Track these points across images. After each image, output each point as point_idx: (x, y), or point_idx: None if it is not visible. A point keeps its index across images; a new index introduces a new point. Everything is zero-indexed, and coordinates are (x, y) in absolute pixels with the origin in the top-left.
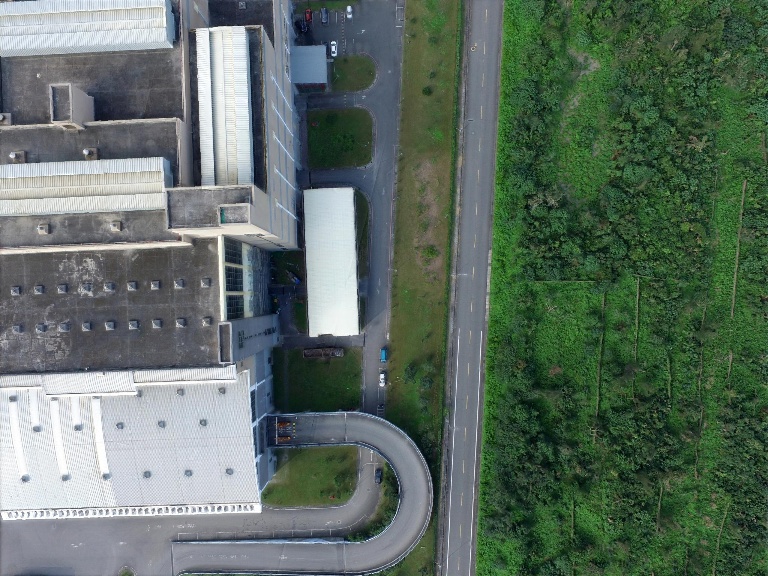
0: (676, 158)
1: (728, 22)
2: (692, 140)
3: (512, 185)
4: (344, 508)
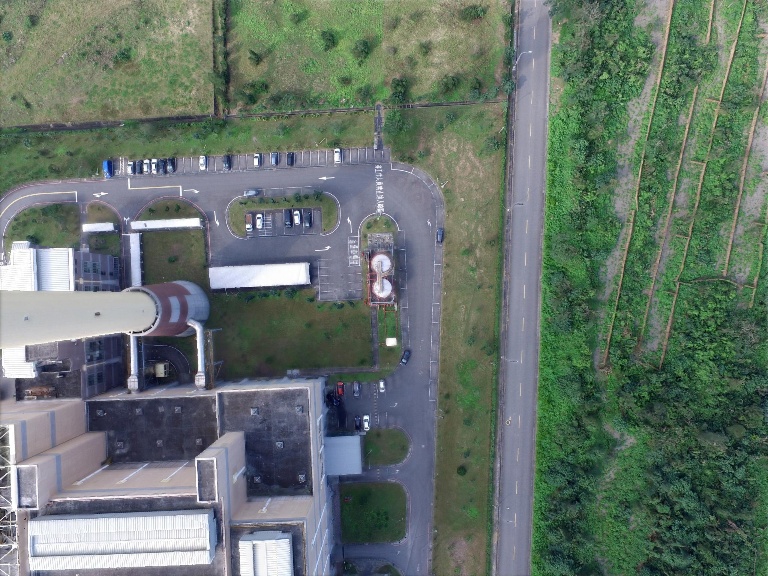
0: (715, 544)
1: (765, 397)
2: (731, 525)
3: (549, 569)
4: None
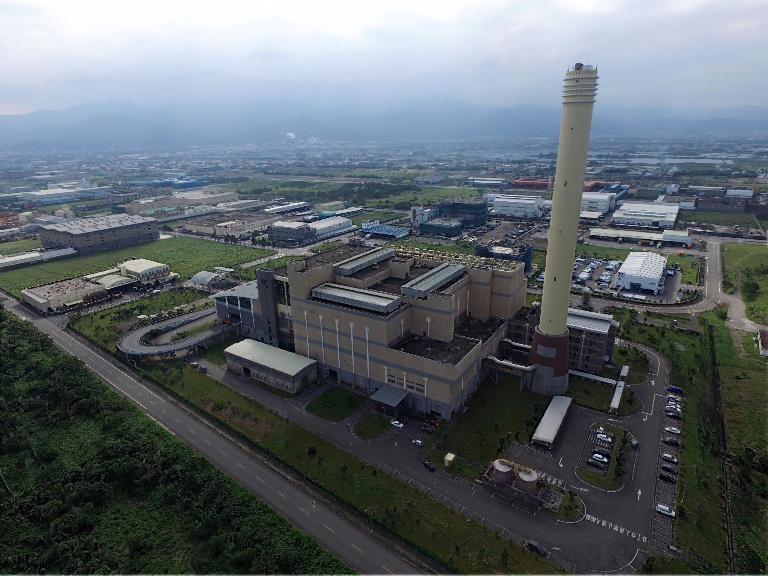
0: None
1: None
2: None
3: None
4: (171, 336)
